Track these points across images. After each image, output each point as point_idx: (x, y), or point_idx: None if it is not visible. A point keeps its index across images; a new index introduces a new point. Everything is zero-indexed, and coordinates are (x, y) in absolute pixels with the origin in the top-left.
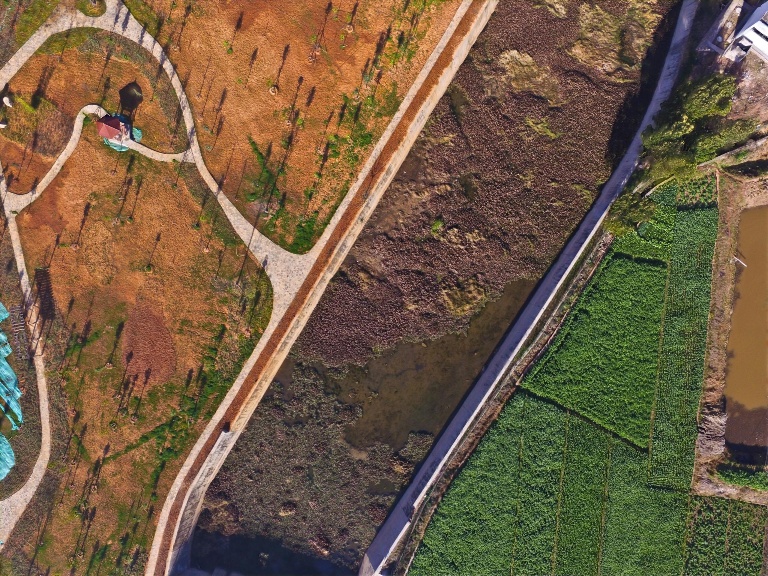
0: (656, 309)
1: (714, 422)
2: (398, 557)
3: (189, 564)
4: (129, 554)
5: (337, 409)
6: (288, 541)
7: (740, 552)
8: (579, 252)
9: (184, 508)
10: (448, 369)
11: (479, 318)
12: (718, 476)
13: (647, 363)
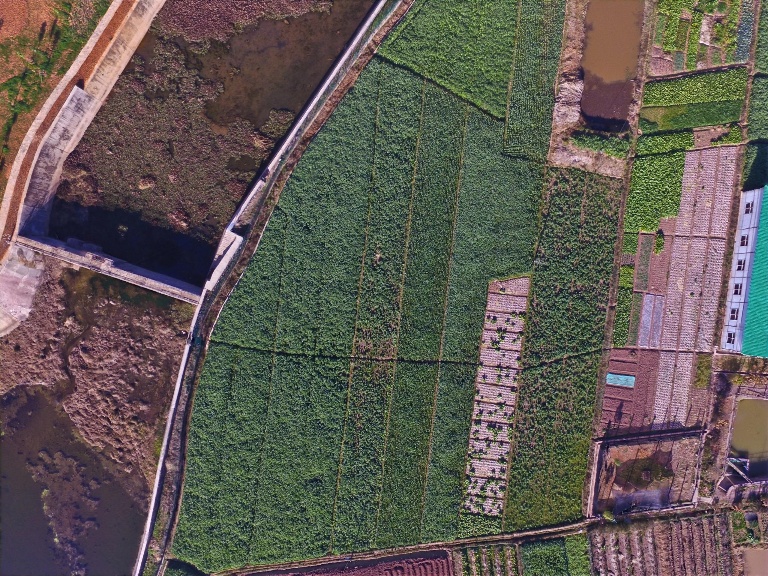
0: None
1: (569, 89)
2: (252, 221)
3: (47, 233)
4: None
5: (198, 85)
6: (147, 214)
7: (595, 224)
8: None
9: (36, 161)
10: (311, 48)
11: None
12: (572, 142)
13: (504, 31)
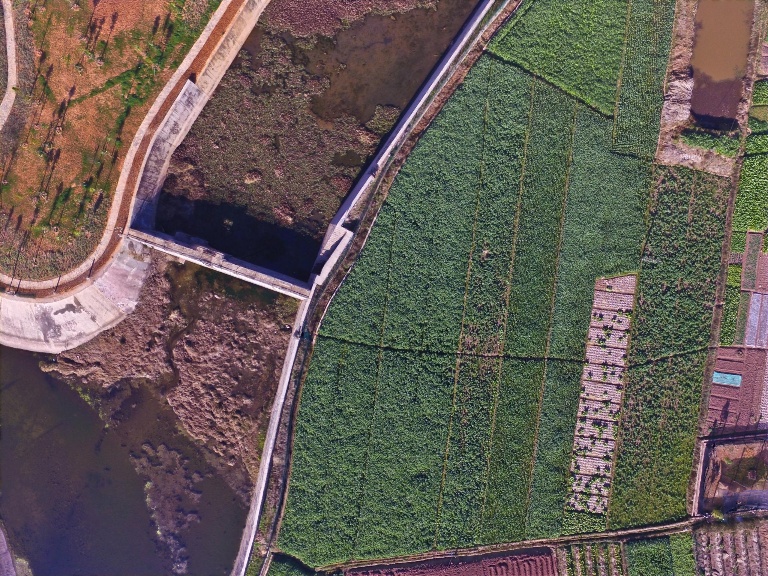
0: None
1: (680, 87)
2: (361, 216)
3: (154, 227)
4: (93, 198)
5: (305, 80)
6: (253, 209)
7: (703, 223)
8: None
9: (148, 155)
10: (417, 44)
11: None
12: (682, 140)
13: (615, 28)
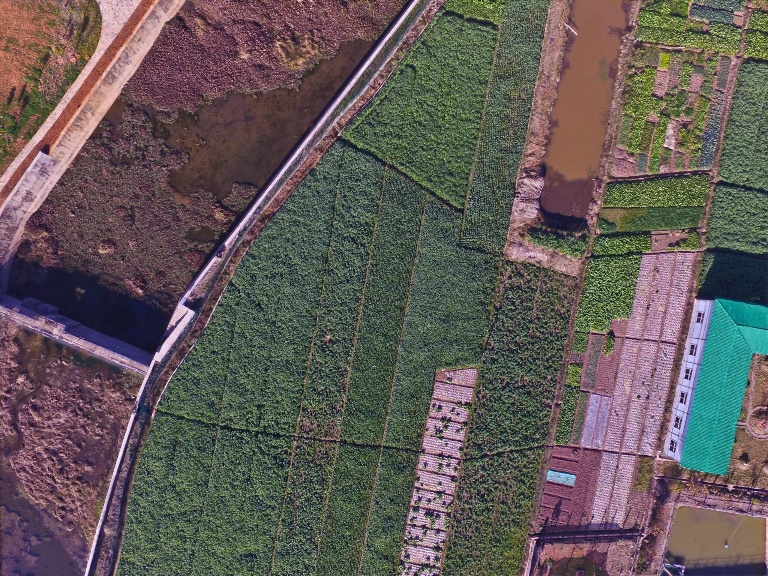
0: (482, 70)
1: (529, 185)
2: (206, 295)
3: (5, 291)
4: None
5: (164, 153)
6: (105, 278)
7: (547, 320)
8: (410, 7)
9: None
10: (278, 123)
11: (312, 75)
12: (528, 238)
13: (468, 123)
